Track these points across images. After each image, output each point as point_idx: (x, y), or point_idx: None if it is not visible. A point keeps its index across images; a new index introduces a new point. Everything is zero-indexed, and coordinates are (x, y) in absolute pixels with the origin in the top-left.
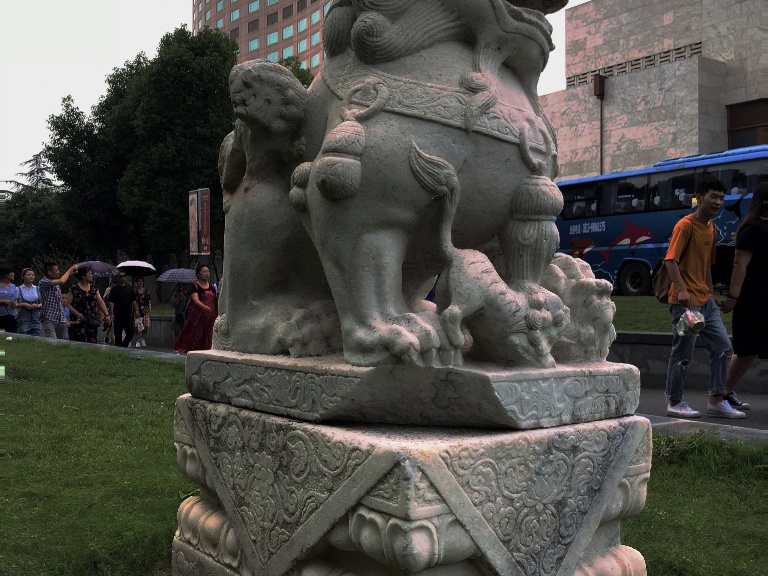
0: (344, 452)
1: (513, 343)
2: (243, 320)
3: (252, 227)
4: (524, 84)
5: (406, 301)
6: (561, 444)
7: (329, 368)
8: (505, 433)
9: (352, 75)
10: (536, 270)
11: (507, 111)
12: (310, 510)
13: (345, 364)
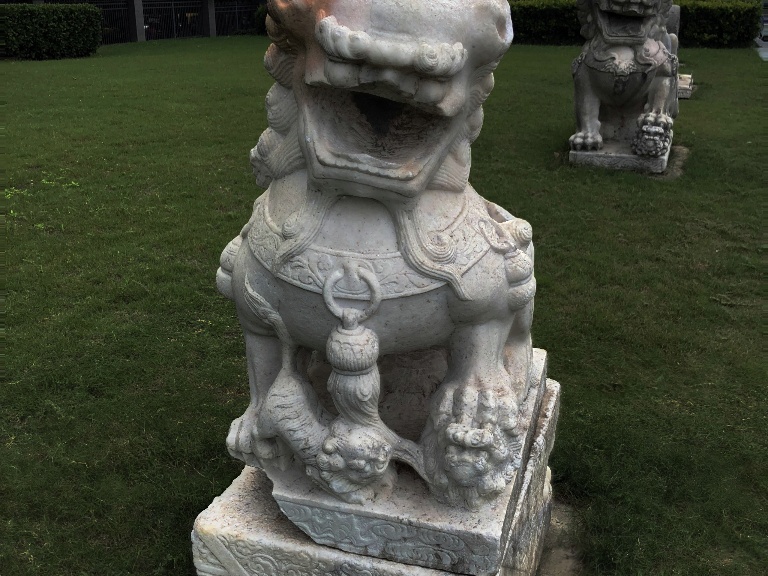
0: None
1: (306, 473)
2: None
3: None
4: (390, 211)
5: (412, 360)
6: (352, 572)
7: None
8: (301, 540)
9: None
10: (347, 414)
11: (316, 259)
12: None
13: None
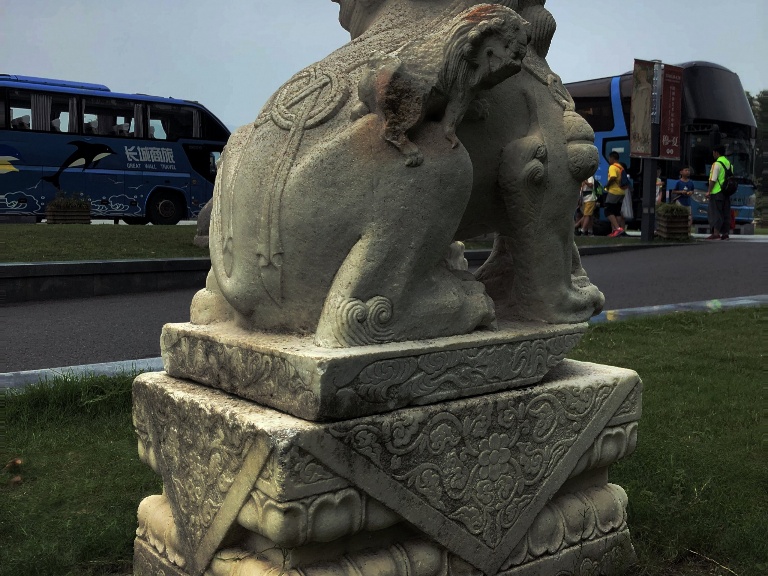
0: (592, 393)
1: None
2: (421, 300)
3: (463, 191)
4: None
5: None
6: None
7: (558, 330)
8: None
9: (537, 61)
10: None
11: None
12: (558, 459)
13: (560, 324)
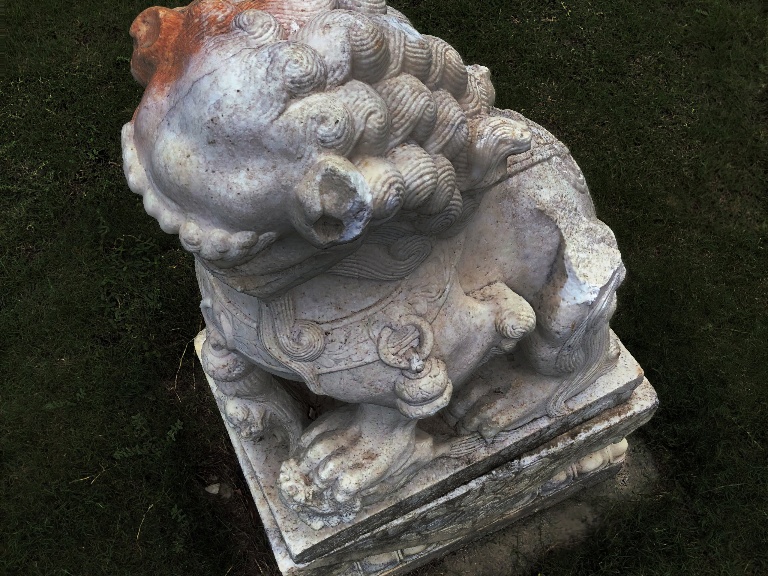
0: None
1: None
2: None
3: None
4: None
5: None
6: None
7: None
8: None
9: None
10: None
11: (203, 275)
12: None
13: None
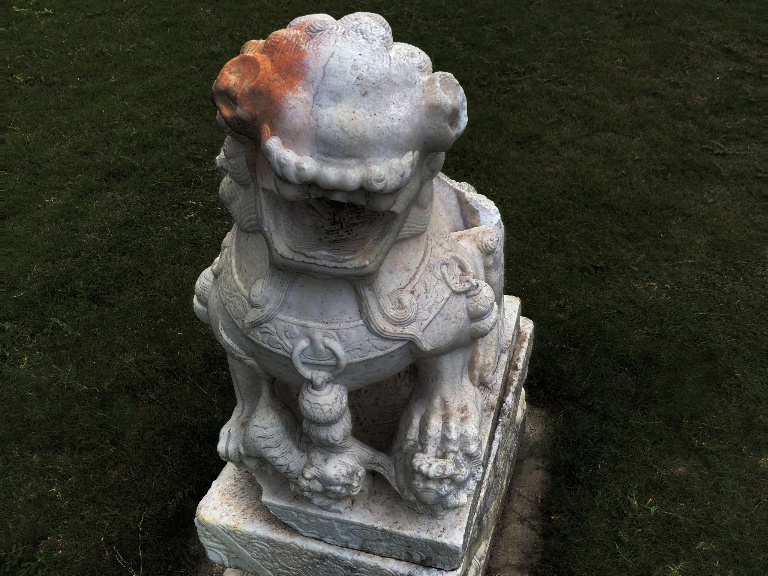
0: None
1: None
2: None
3: None
4: None
5: None
6: (336, 561)
7: None
8: (291, 531)
9: None
10: None
11: (283, 328)
12: None
13: None
